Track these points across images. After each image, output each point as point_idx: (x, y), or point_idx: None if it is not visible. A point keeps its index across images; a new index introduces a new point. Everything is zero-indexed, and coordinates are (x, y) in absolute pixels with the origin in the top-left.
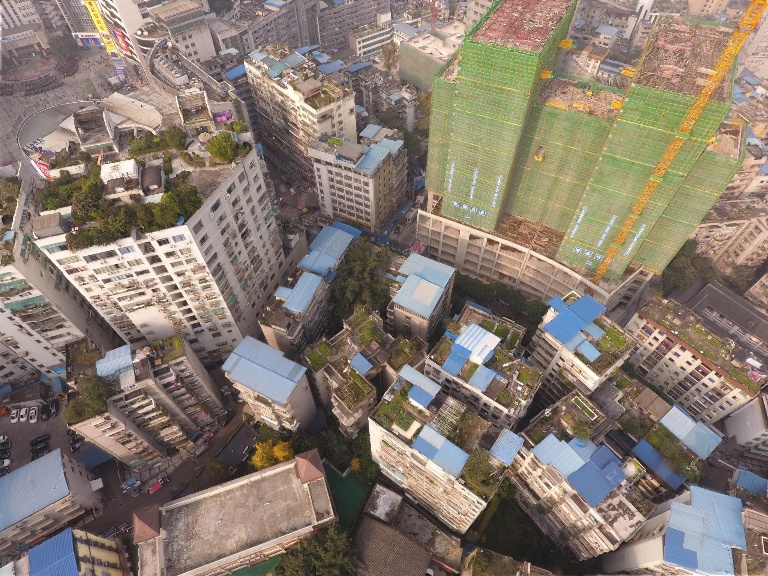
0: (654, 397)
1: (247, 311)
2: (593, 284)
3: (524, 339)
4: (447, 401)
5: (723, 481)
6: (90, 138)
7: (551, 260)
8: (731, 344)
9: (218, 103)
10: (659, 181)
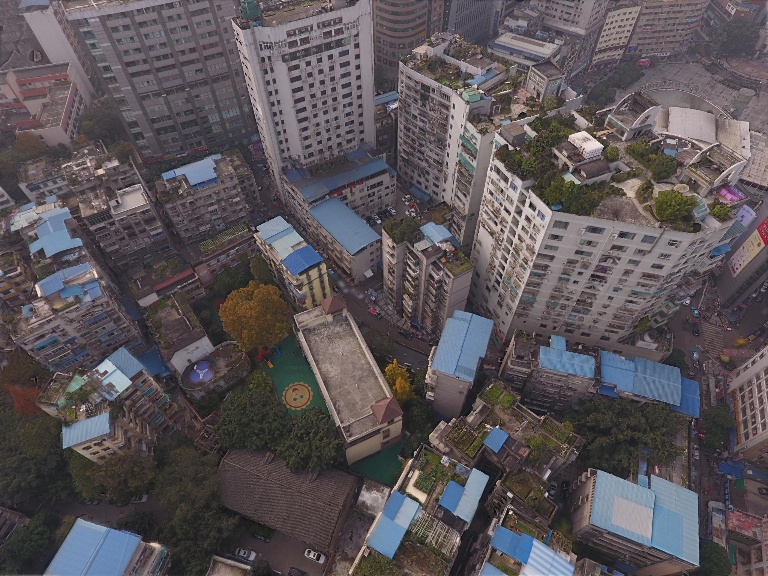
0: None
1: (533, 321)
2: None
3: None
4: (453, 530)
5: None
6: (623, 115)
7: None
8: None
9: None
10: None
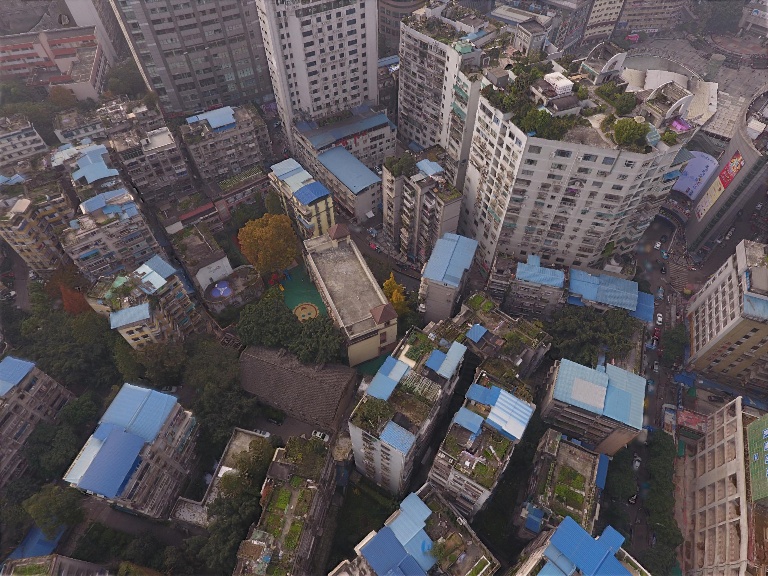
0: None
1: (514, 248)
2: None
3: None
4: (436, 384)
5: None
6: (595, 63)
7: None
8: None
9: (752, 146)
10: None
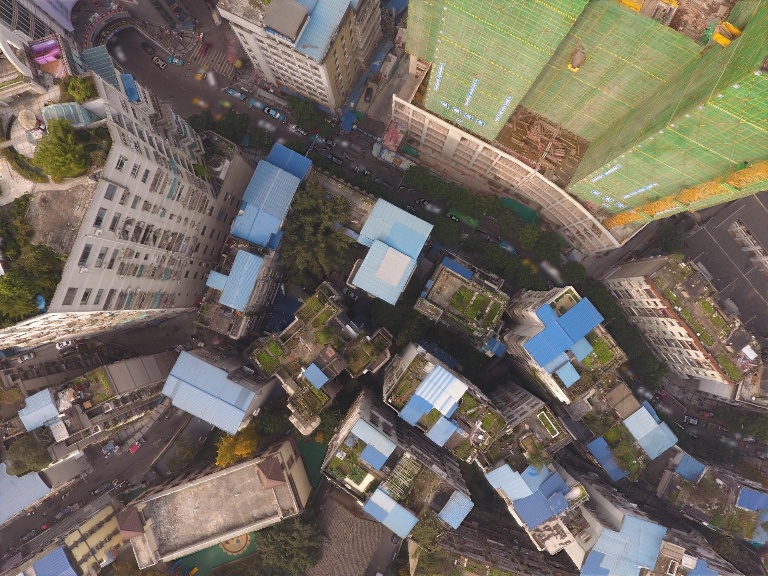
0: (626, 394)
1: (180, 286)
2: (604, 229)
3: (509, 277)
4: (401, 461)
5: (665, 460)
6: None
7: (560, 190)
8: (736, 324)
9: None
10: (732, 191)
